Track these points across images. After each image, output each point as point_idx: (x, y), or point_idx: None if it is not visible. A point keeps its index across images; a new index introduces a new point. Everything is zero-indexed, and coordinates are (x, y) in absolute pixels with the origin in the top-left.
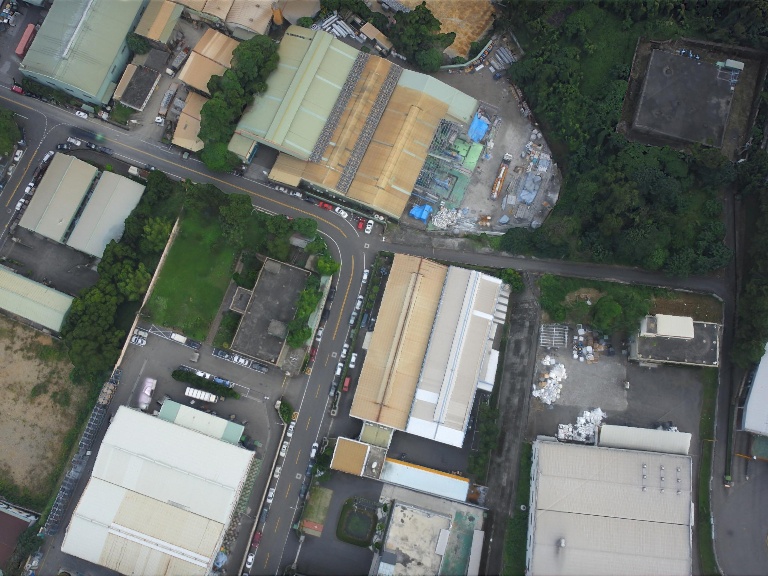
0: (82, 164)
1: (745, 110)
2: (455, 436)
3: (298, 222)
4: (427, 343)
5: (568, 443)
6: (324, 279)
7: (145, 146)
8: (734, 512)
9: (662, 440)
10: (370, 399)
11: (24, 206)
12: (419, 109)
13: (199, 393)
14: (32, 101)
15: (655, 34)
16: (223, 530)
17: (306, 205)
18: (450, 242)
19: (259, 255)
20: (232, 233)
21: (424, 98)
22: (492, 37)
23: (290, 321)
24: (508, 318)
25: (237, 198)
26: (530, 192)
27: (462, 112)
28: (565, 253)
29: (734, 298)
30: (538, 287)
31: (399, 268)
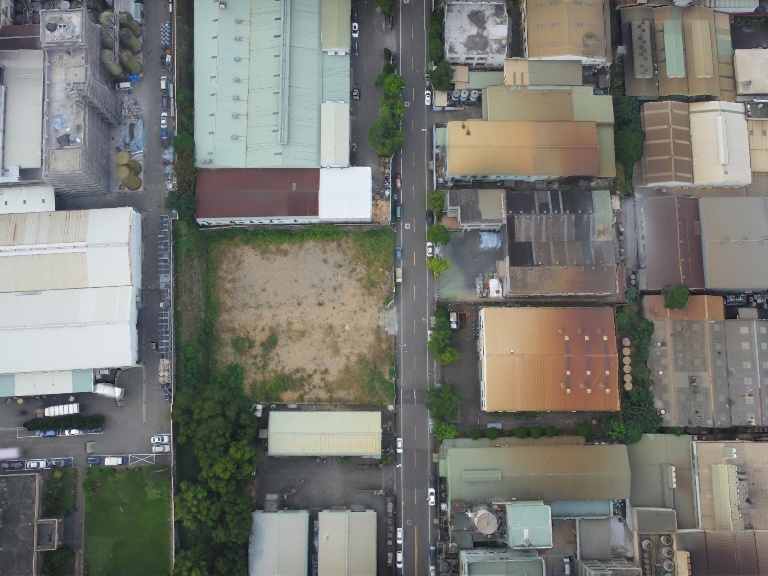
0: None
1: None
2: None
3: None
4: None
5: None
6: None
7: None
8: None
9: None
10: None
11: (390, 536)
12: None
13: (62, 412)
14: None
15: None
16: None
17: None
18: None
19: None
20: None
21: None
22: None
23: None
24: None
25: None
26: None
27: None
28: None
29: None
30: None
31: None
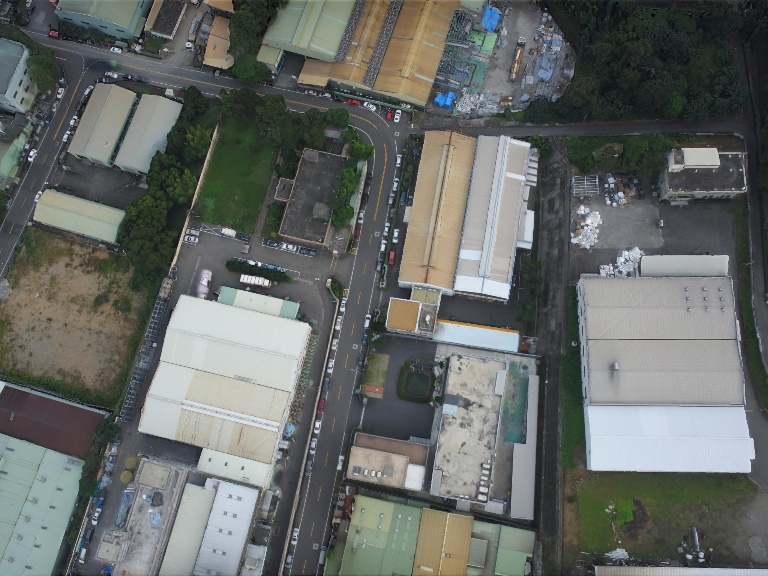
0: (122, 90)
1: None
2: (501, 288)
3: (331, 112)
4: (465, 209)
5: None
6: (360, 165)
7: (178, 71)
8: None
9: (701, 265)
10: (416, 264)
11: (70, 136)
12: (433, 3)
13: (253, 279)
14: (68, 44)
15: None
16: (289, 399)
17: (335, 104)
18: (476, 121)
19: (296, 151)
20: (270, 130)
21: None
22: None
23: (333, 200)
24: (539, 183)
25: (271, 98)
26: (547, 70)
27: (474, 3)
28: (587, 112)
29: (755, 135)
30: (565, 148)
31: (431, 144)
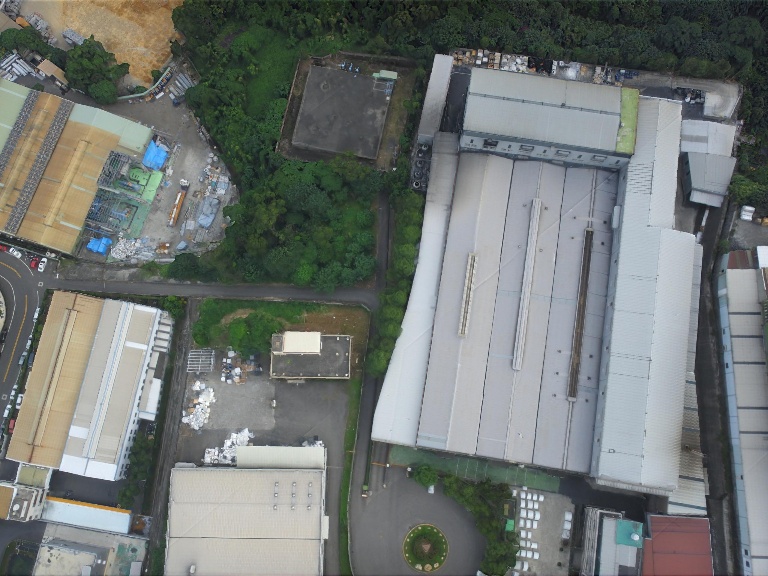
0: None
1: (402, 118)
2: (107, 470)
3: None
4: None
5: (214, 467)
6: None
7: None
8: (371, 521)
9: (296, 456)
10: (24, 440)
11: None
12: (87, 143)
13: None
14: None
15: (316, 50)
16: None
17: None
18: (122, 273)
19: None
20: None
21: (93, 131)
22: (170, 64)
23: None
24: (176, 345)
25: None
26: (207, 216)
27: (135, 142)
28: (219, 276)
29: None
30: (198, 312)
31: (57, 305)
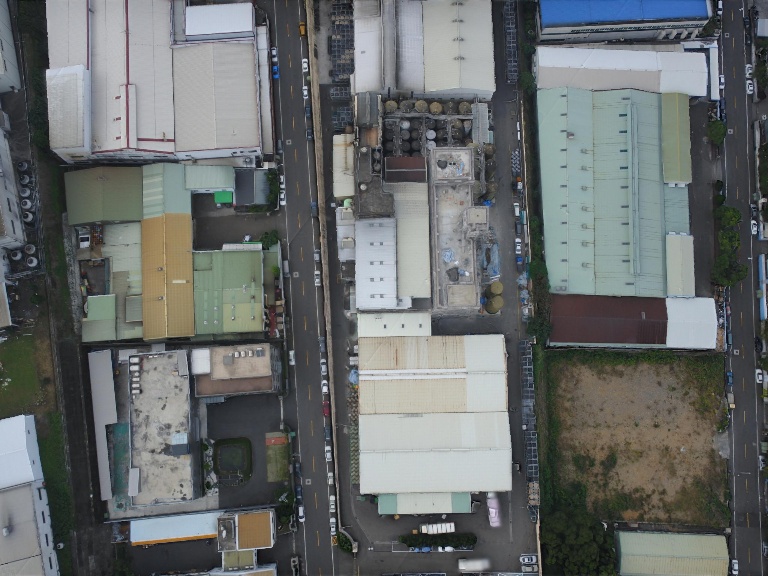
0: None
1: None
2: None
3: None
4: None
5: None
6: None
7: None
8: None
9: None
10: None
11: None
12: None
13: (440, 530)
14: None
15: None
16: None
17: None
18: None
19: None
20: None
21: None
22: None
23: None
24: None
25: None
26: None
27: None
28: None
29: None
30: None
31: None
